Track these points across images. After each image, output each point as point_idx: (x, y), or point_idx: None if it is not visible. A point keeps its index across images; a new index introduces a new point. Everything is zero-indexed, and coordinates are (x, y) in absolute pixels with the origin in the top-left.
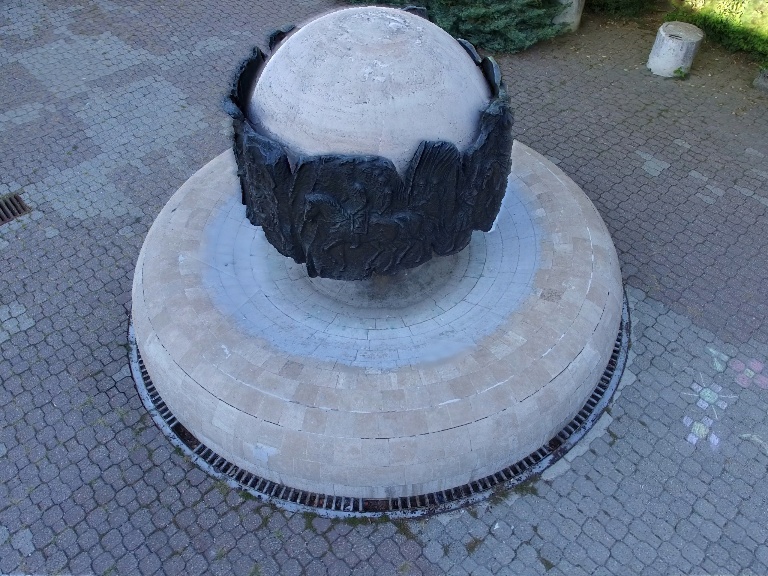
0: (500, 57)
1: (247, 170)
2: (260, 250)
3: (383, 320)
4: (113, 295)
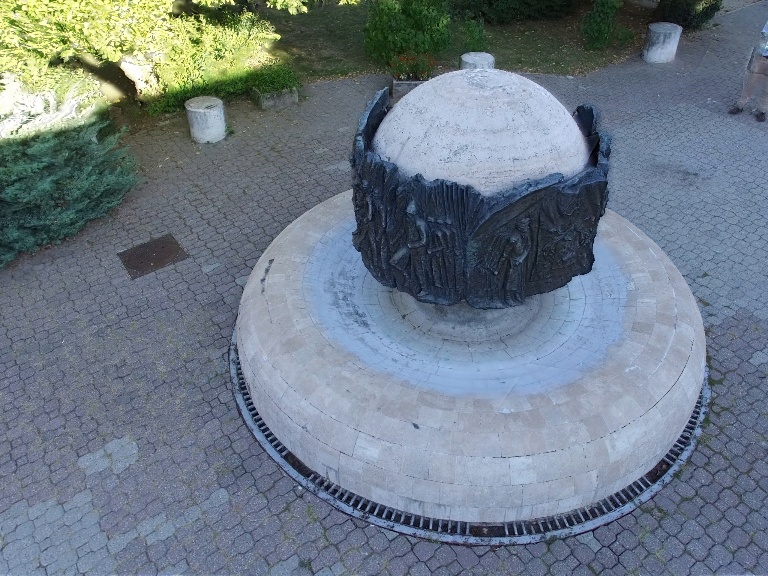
0: (116, 214)
1: (560, 227)
2: (468, 366)
3: (557, 293)
4: (462, 573)
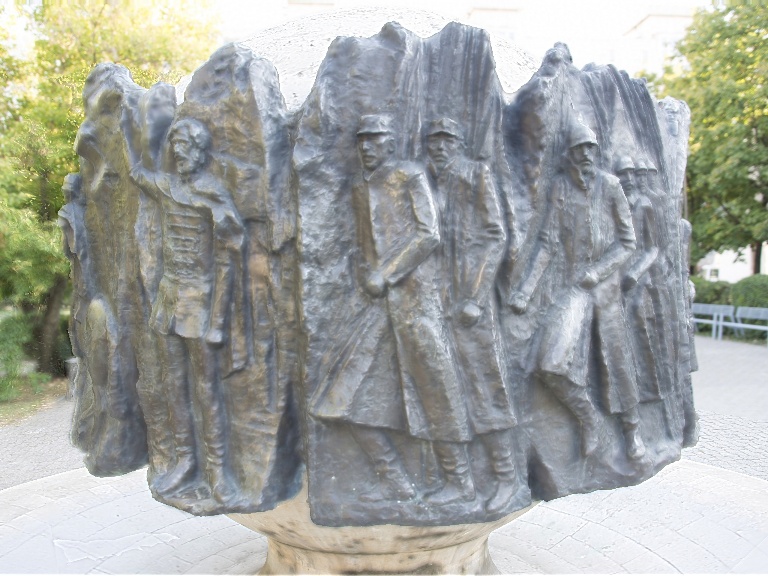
0: None
1: None
2: None
3: None
4: None
